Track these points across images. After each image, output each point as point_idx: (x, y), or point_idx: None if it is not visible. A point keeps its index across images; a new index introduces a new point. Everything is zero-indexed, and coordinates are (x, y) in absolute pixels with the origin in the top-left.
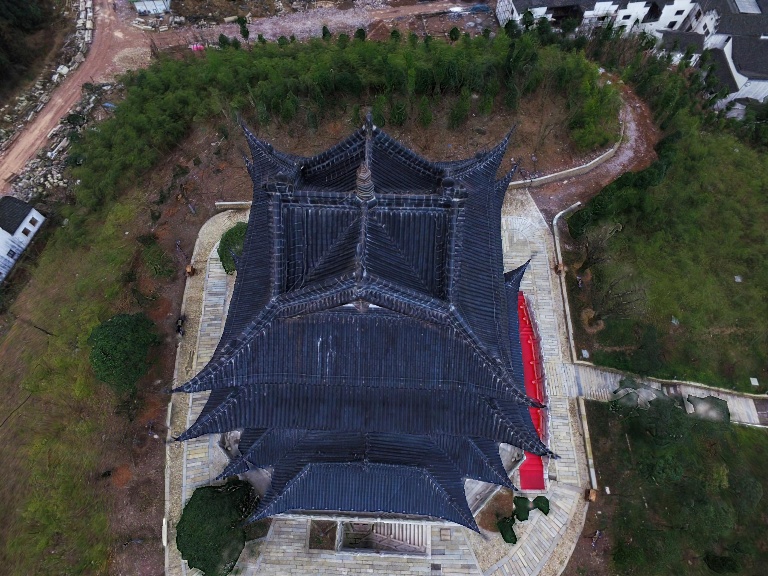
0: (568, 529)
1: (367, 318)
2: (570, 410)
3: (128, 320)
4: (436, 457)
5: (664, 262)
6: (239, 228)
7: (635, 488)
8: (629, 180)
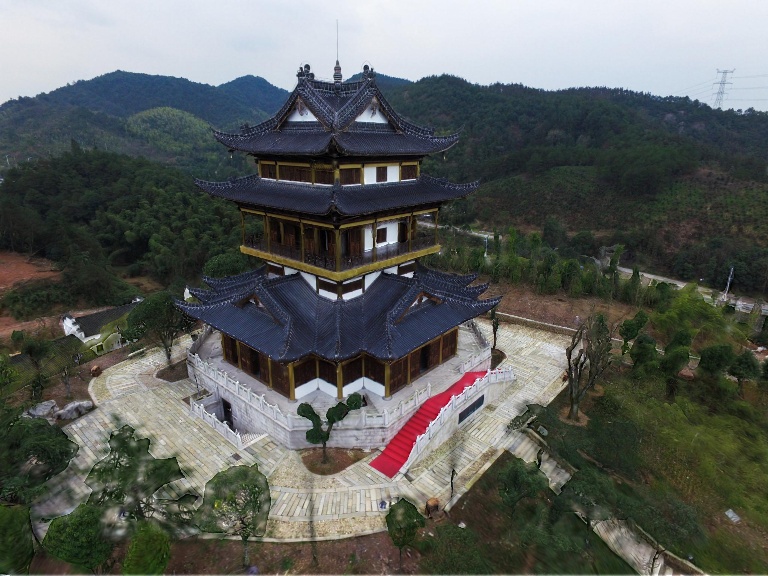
0: (379, 517)
1: (305, 132)
2: (484, 454)
3: None
4: (308, 331)
5: (723, 434)
6: None
7: (510, 573)
8: (684, 336)
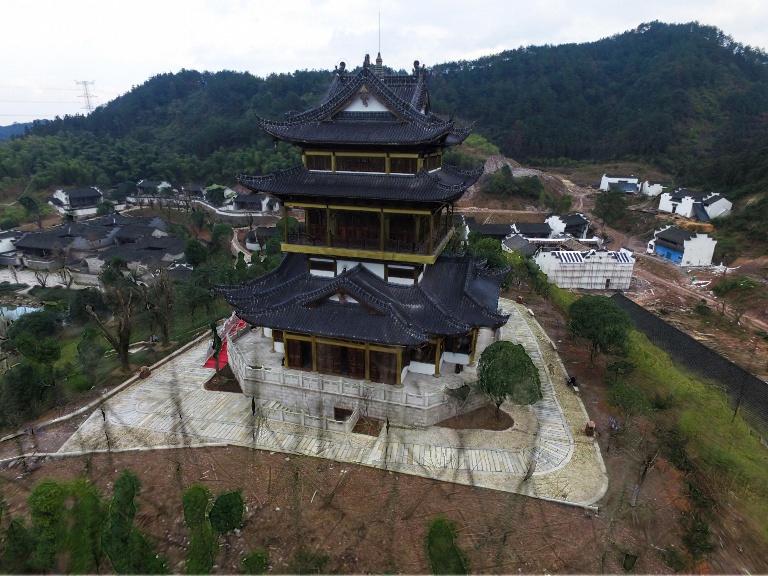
0: None
1: None
2: None
3: (596, 310)
4: None
5: None
6: (511, 362)
7: None
8: None
